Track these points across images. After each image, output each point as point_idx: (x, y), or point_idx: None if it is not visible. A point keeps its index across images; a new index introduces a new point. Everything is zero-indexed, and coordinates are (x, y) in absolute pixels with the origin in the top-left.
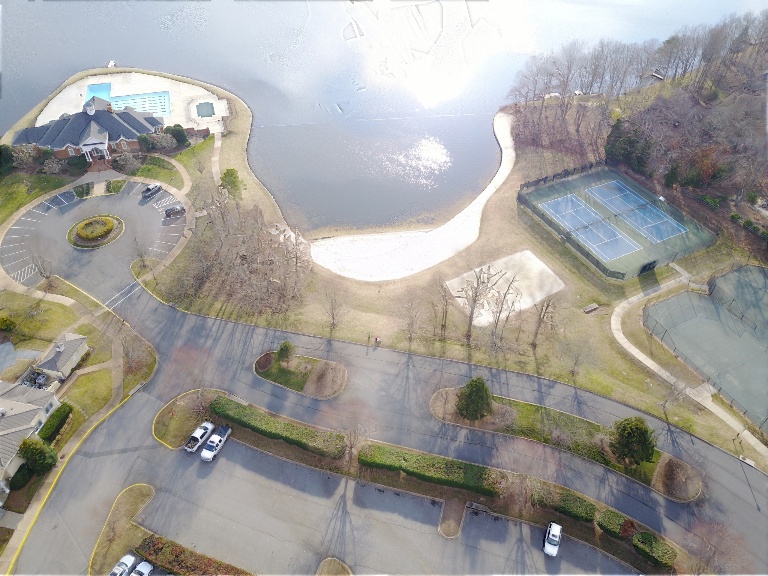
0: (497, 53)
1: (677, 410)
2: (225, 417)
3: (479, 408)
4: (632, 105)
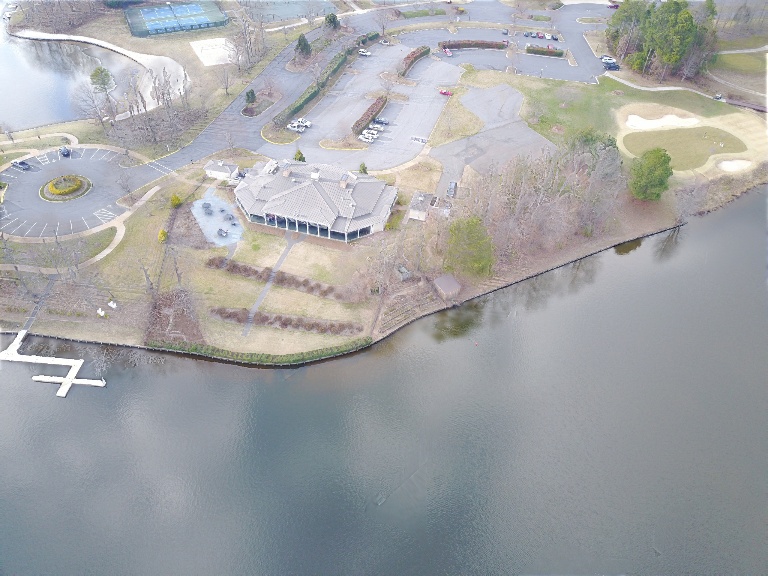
0: None
1: None
2: None
3: None
4: None
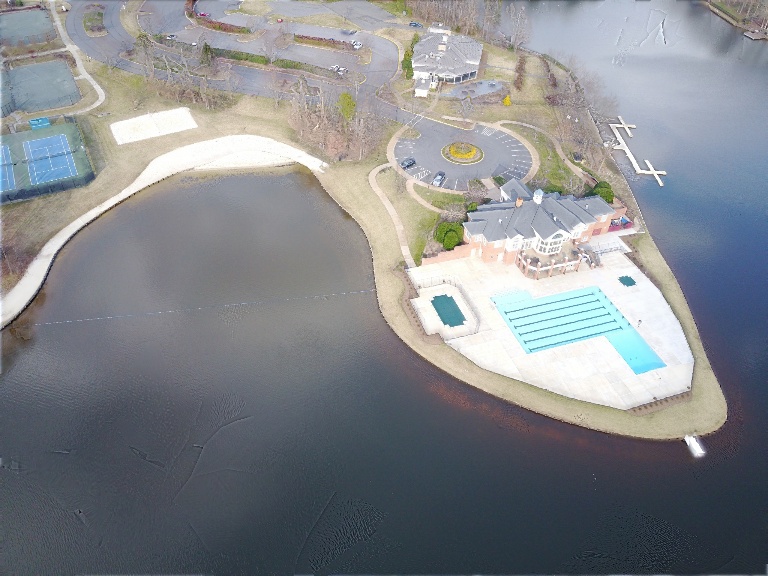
0: None
1: (105, 71)
2: None
3: None
4: None
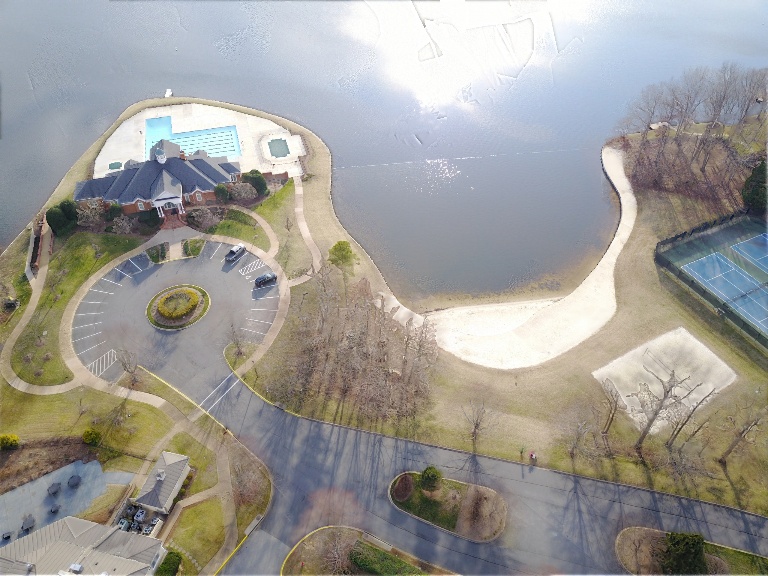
0: (590, 75)
1: None
2: (369, 571)
3: (696, 572)
4: None
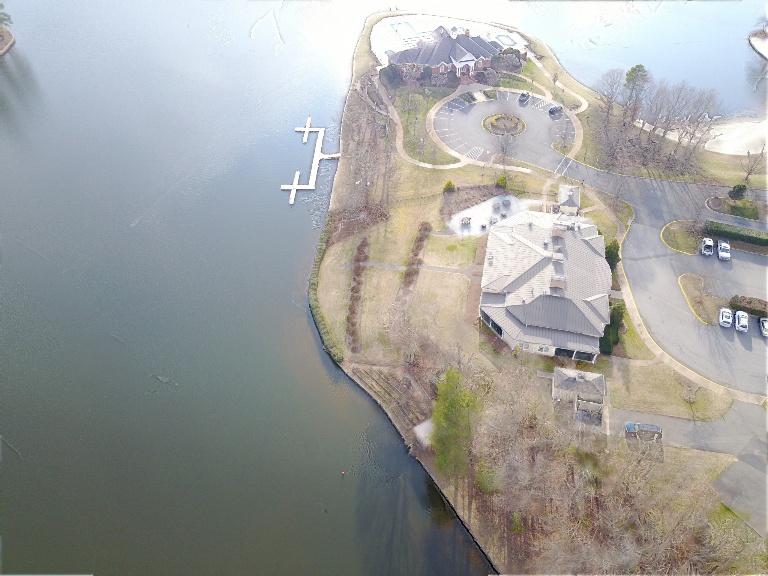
0: None
1: None
2: (719, 234)
3: None
4: None
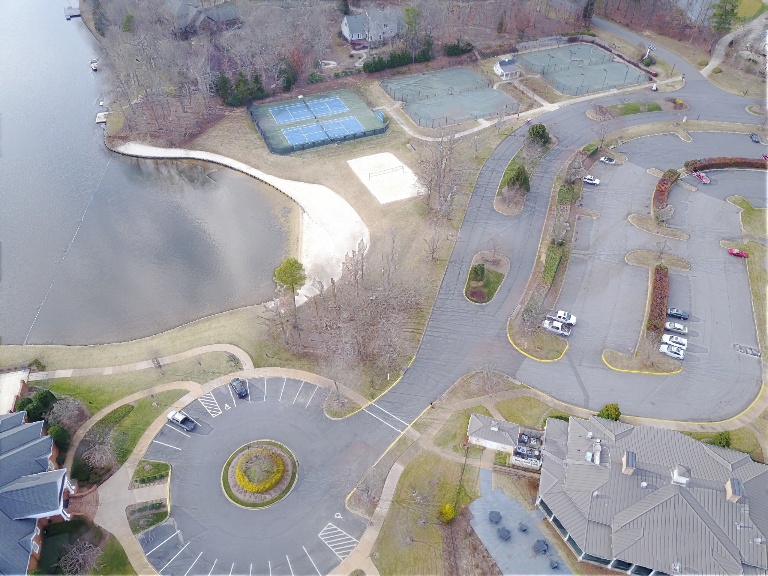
0: None
1: None
2: None
3: None
4: (214, 62)
